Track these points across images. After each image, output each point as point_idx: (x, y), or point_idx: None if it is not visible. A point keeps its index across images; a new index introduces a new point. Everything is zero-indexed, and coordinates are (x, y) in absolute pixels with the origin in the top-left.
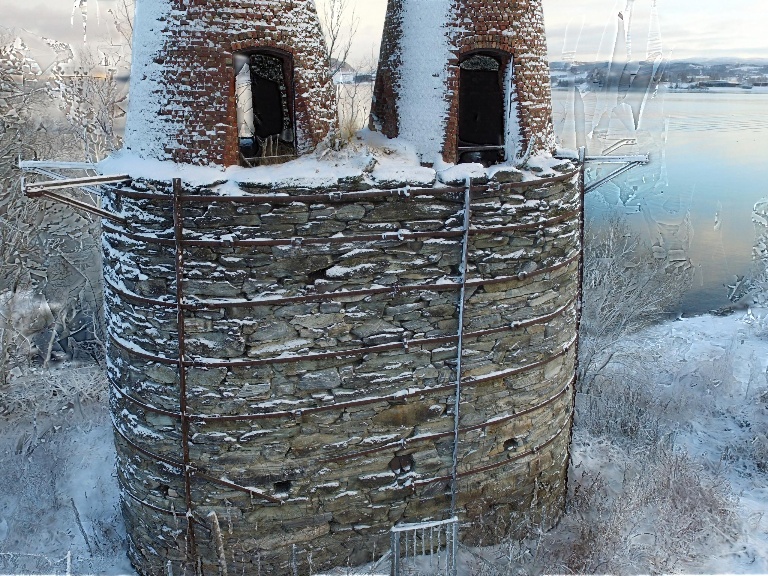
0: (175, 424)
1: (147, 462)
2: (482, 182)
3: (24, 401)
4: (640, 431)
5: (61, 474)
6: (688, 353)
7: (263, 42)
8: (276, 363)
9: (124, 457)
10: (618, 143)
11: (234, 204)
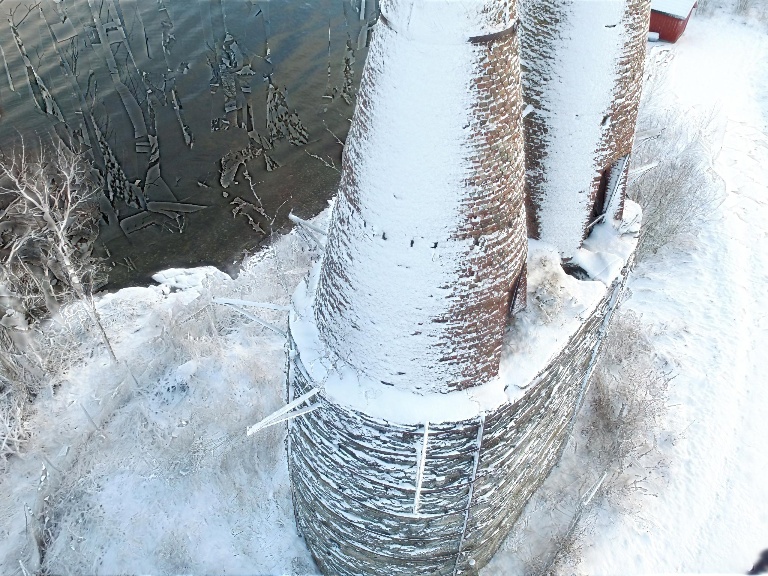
0: None
1: None
2: None
3: None
4: None
5: None
6: None
7: (522, 265)
8: None
9: None
10: None
11: (518, 402)
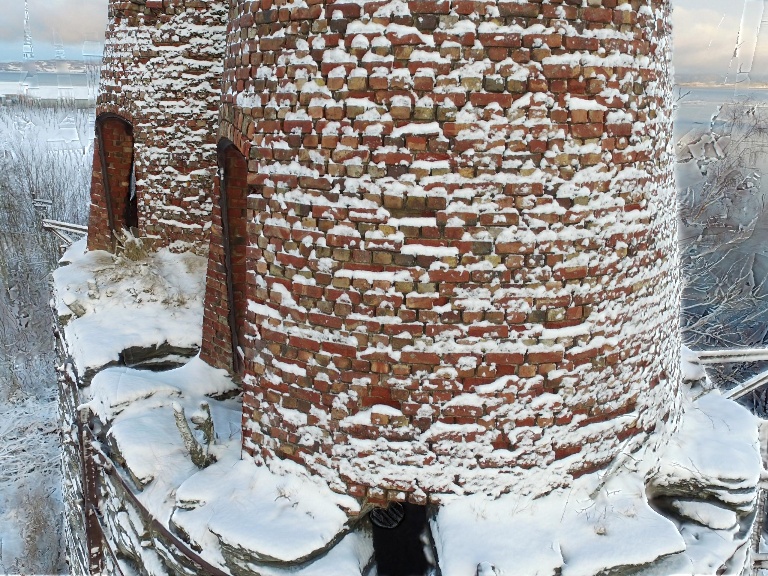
0: None
1: None
2: None
3: None
4: None
5: None
6: None
7: None
8: None
9: None
10: None
11: None
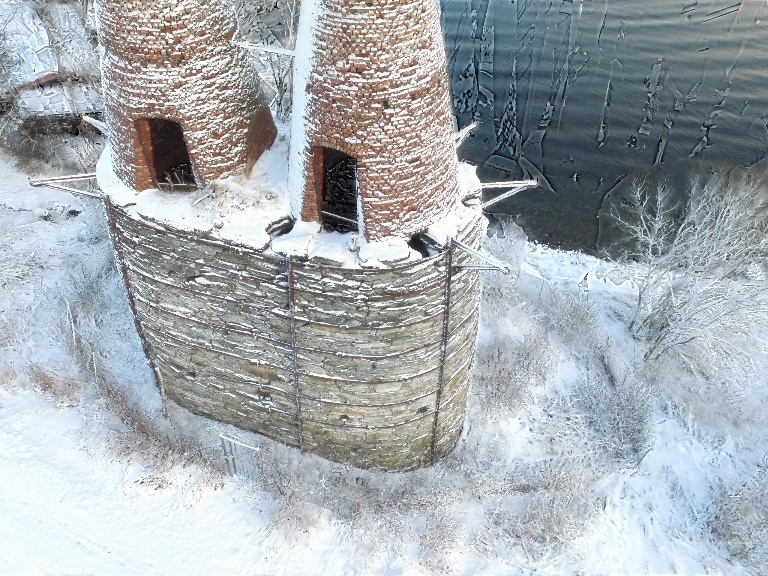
0: None
1: None
2: (304, 259)
3: None
4: None
5: None
6: None
7: (154, 115)
8: (174, 315)
9: None
10: None
11: (136, 223)
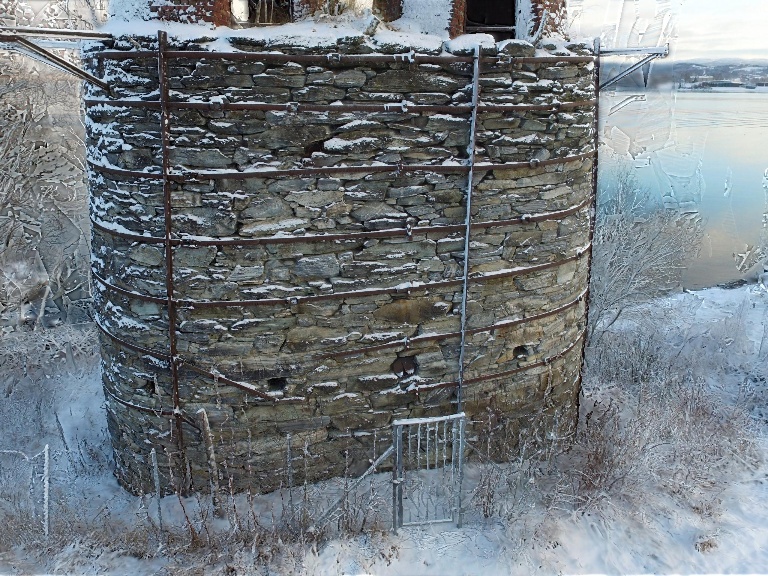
0: (162, 312)
1: (132, 358)
2: (492, 54)
3: (16, 354)
4: (652, 378)
5: (48, 406)
6: (697, 319)
7: None
8: (270, 244)
9: (109, 358)
10: (627, 99)
11: (224, 62)
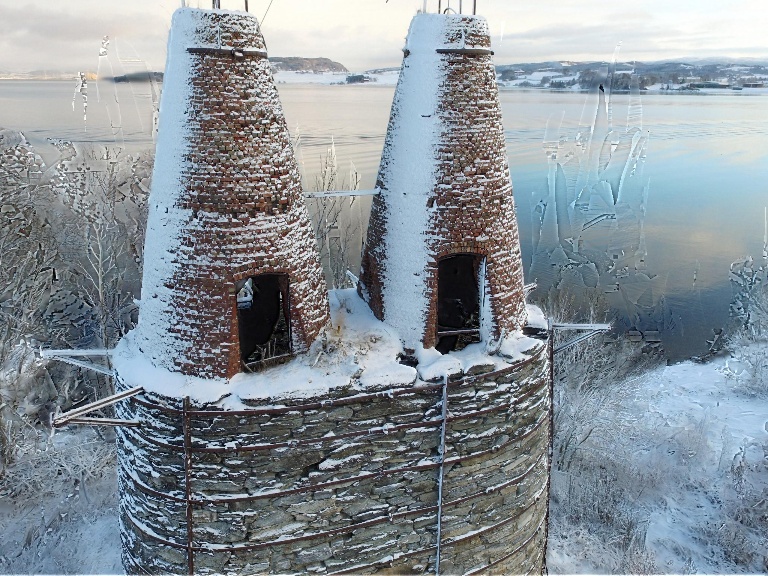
0: None
1: None
2: (458, 376)
3: (30, 483)
4: (615, 519)
5: None
6: (667, 411)
7: (262, 270)
8: (274, 545)
9: None
10: (598, 217)
11: (237, 417)
